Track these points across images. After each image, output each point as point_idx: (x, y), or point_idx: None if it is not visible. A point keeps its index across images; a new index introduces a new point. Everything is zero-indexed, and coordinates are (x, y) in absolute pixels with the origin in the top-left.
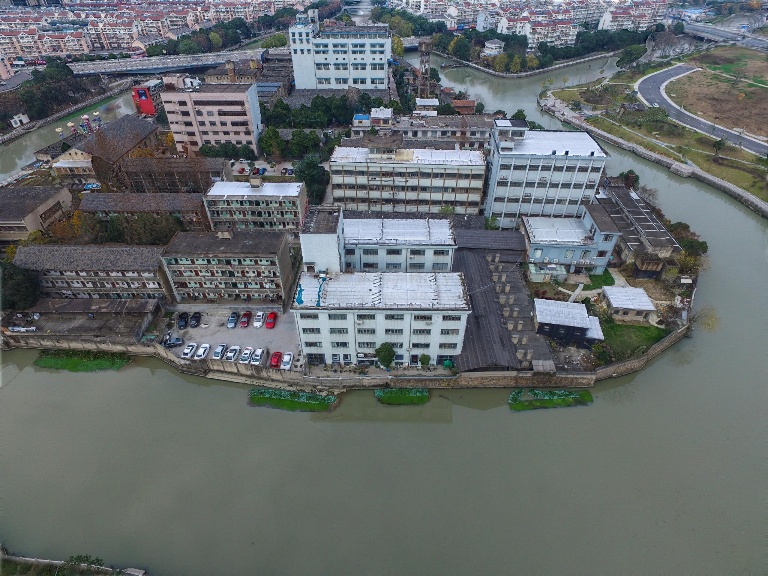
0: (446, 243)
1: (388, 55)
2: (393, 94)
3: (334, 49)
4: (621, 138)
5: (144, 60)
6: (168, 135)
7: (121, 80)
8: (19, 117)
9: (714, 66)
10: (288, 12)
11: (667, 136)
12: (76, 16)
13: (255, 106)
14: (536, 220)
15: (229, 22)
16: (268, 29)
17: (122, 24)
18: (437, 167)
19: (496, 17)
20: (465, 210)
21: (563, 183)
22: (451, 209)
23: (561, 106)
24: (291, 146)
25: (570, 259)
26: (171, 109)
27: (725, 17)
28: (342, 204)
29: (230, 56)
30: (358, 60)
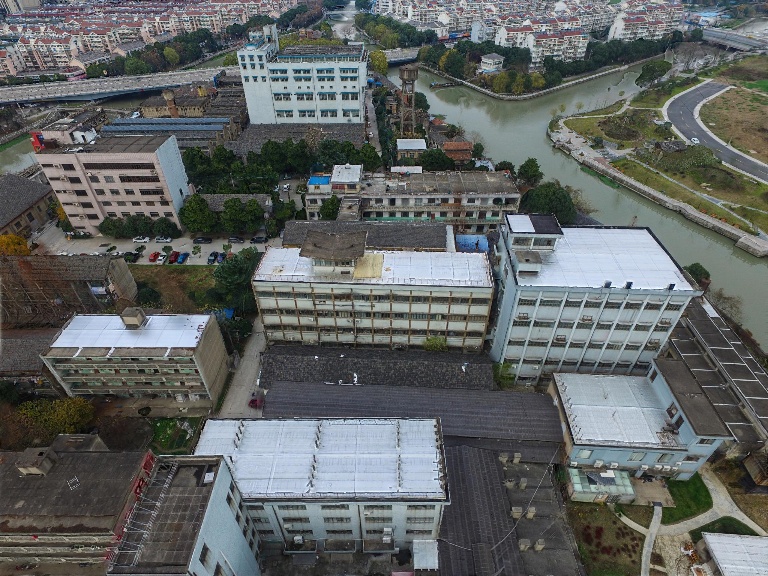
0: (429, 496)
1: (363, 82)
2: (372, 126)
3: (295, 75)
4: (662, 192)
5: (80, 83)
6: (60, 204)
7: (45, 110)
8: None
9: (749, 83)
10: (261, 20)
11: (722, 189)
12: (11, 30)
13: (176, 165)
14: (576, 382)
15: (191, 33)
16: (238, 40)
17: (57, 40)
18: (418, 289)
19: (493, 26)
20: (462, 341)
21: (619, 324)
22: (441, 340)
23: (578, 142)
24: (223, 221)
25: (637, 462)
26: (54, 174)
27: (744, 21)
28: (279, 332)
29: (184, 77)
30: (326, 88)
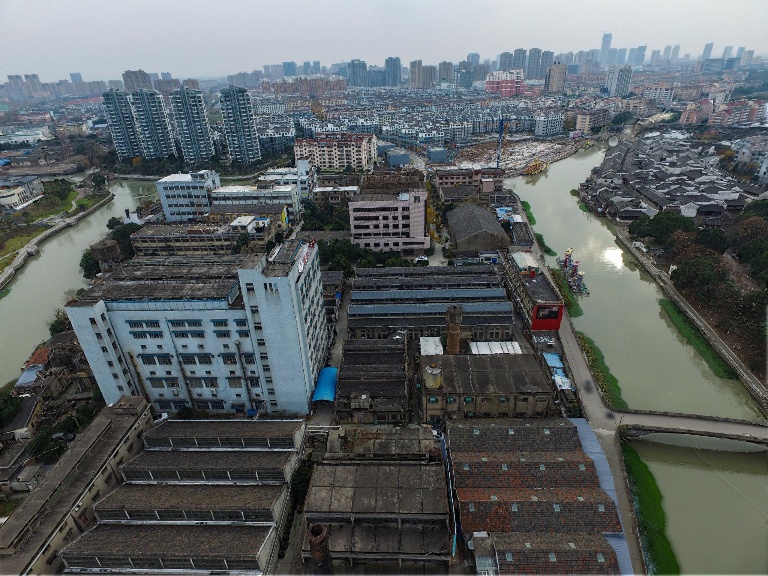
0: None
1: None
2: None
3: None
4: None
5: None
6: None
7: None
8: None
9: None
10: None
11: None
12: None
13: None
14: None
15: None
16: None
17: None
18: None
19: None
20: None
21: None
22: None
23: None
24: None
25: None
26: None
27: None
28: None
29: None
30: None
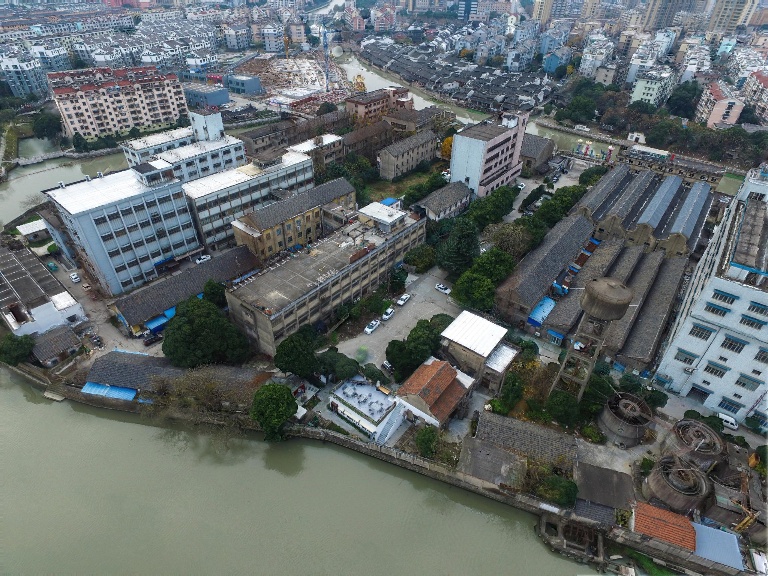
0: None
1: None
2: None
3: None
4: None
5: None
6: None
7: None
8: (640, 136)
9: None
10: None
11: None
12: None
13: (476, 161)
14: None
15: None
16: None
17: None
18: None
19: None
20: None
21: None
22: None
23: None
24: None
25: None
26: None
27: None
28: None
29: None
30: None
